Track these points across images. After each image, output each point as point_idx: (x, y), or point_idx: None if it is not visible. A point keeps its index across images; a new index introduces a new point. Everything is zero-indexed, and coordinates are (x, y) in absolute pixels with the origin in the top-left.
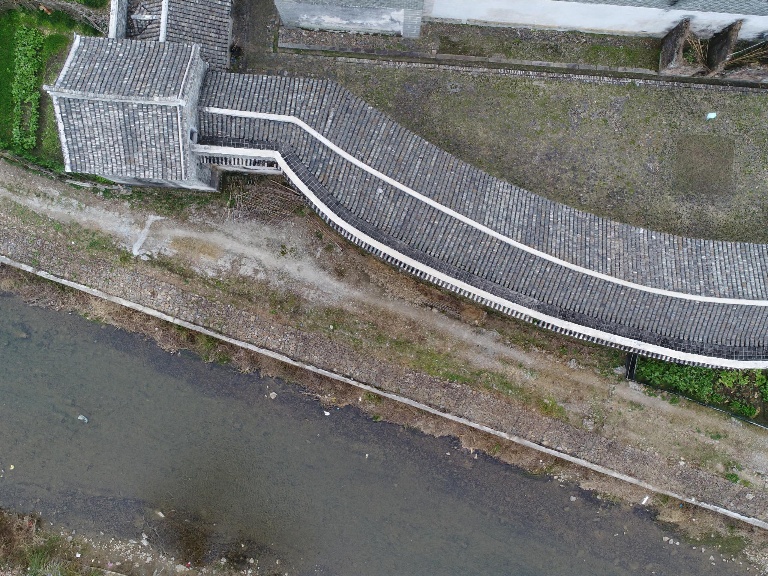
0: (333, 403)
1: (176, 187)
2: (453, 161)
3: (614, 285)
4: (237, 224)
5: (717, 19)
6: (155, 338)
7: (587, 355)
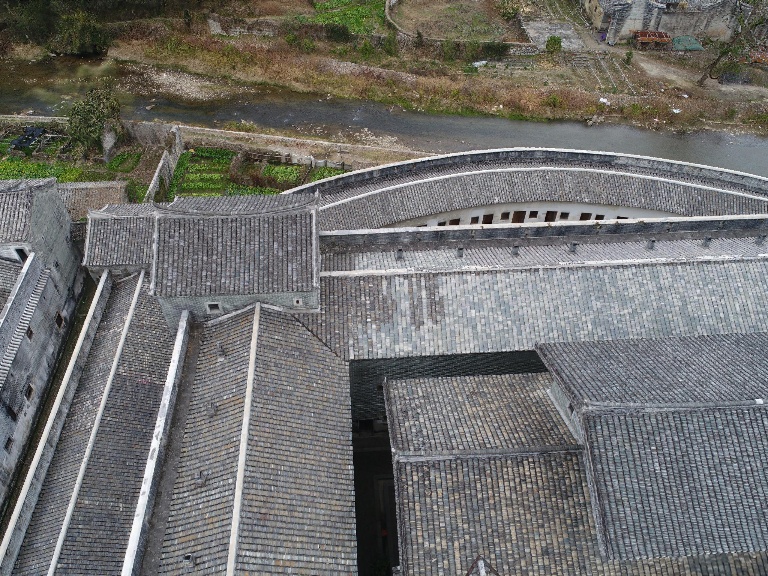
0: None
1: None
2: None
3: None
4: None
5: None
6: None
7: None
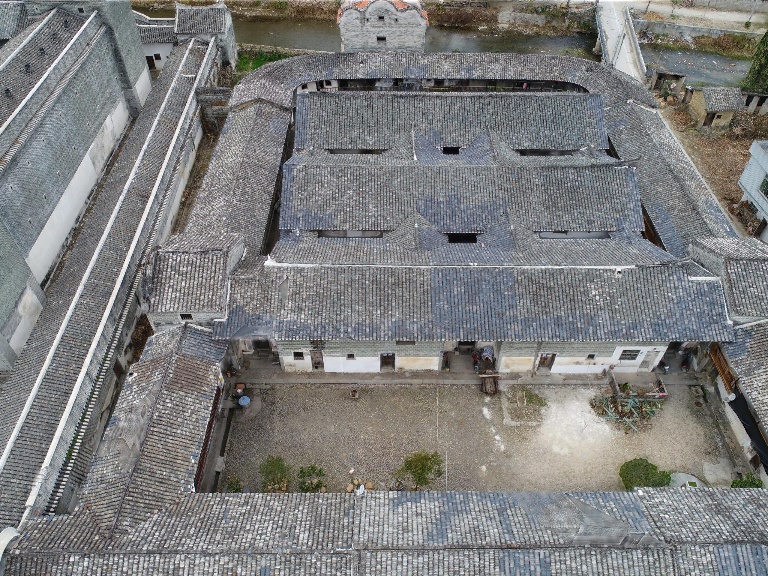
0: None
1: None
2: None
3: None
4: None
5: None
6: None
7: None
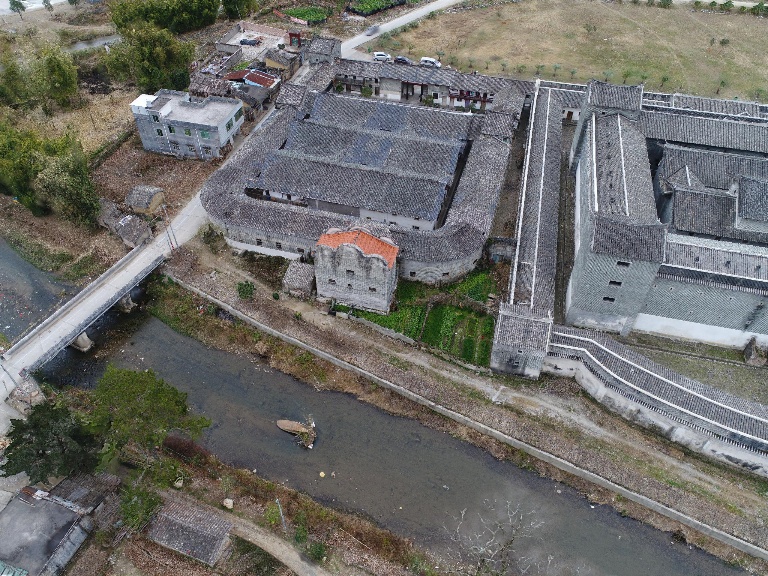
0: (596, 501)
1: (519, 373)
2: (662, 367)
3: (755, 420)
4: (545, 395)
5: (767, 339)
6: (491, 451)
7: (747, 484)
